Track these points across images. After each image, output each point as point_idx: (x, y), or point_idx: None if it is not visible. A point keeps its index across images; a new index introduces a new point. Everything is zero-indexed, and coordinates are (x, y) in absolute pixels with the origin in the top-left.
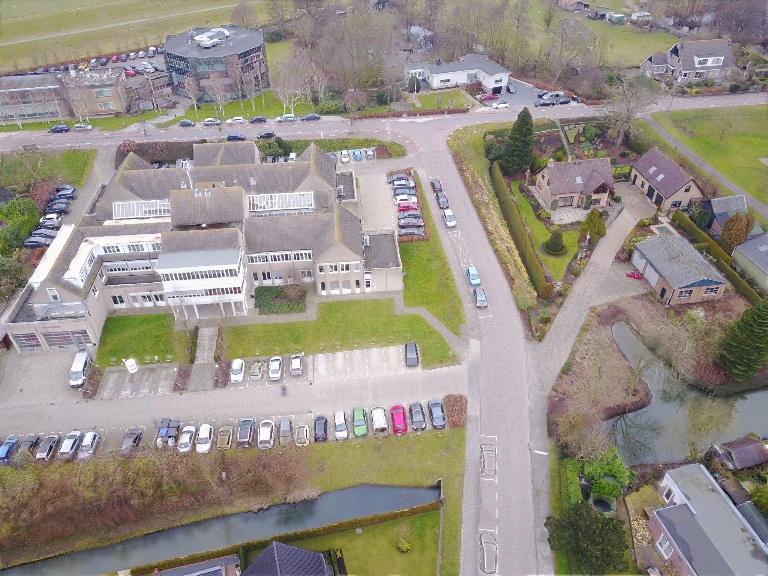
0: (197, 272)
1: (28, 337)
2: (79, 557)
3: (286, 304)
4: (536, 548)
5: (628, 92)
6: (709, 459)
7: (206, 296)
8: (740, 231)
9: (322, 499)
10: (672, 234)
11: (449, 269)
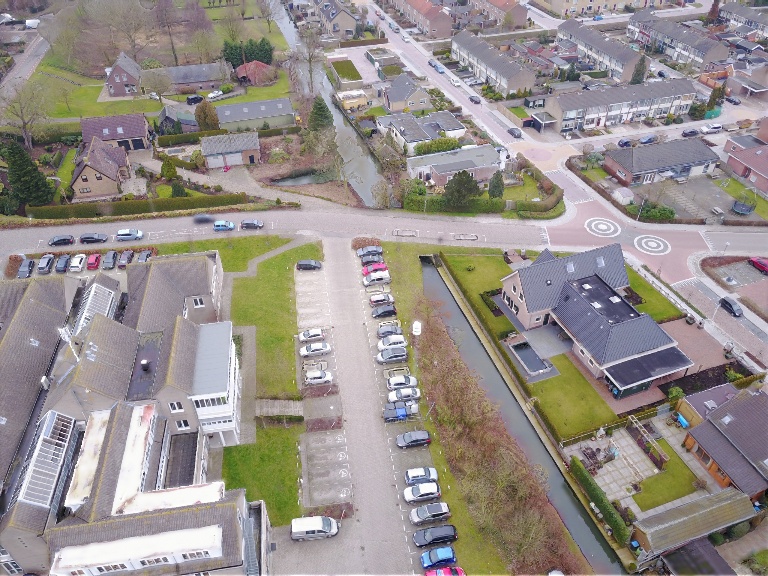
0: None
1: None
2: None
3: None
4: (459, 222)
5: (5, 100)
6: (392, 166)
7: (235, 386)
8: (214, 111)
9: None
10: (180, 149)
11: (207, 240)
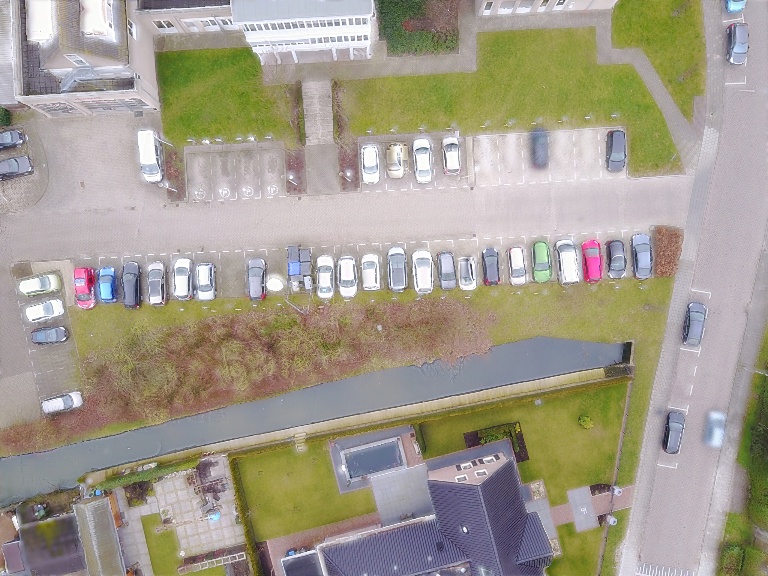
0: (301, 21)
1: (56, 103)
2: (241, 410)
3: (428, 36)
4: (725, 430)
5: None
6: None
7: (312, 44)
8: None
9: (492, 353)
10: None
11: None
